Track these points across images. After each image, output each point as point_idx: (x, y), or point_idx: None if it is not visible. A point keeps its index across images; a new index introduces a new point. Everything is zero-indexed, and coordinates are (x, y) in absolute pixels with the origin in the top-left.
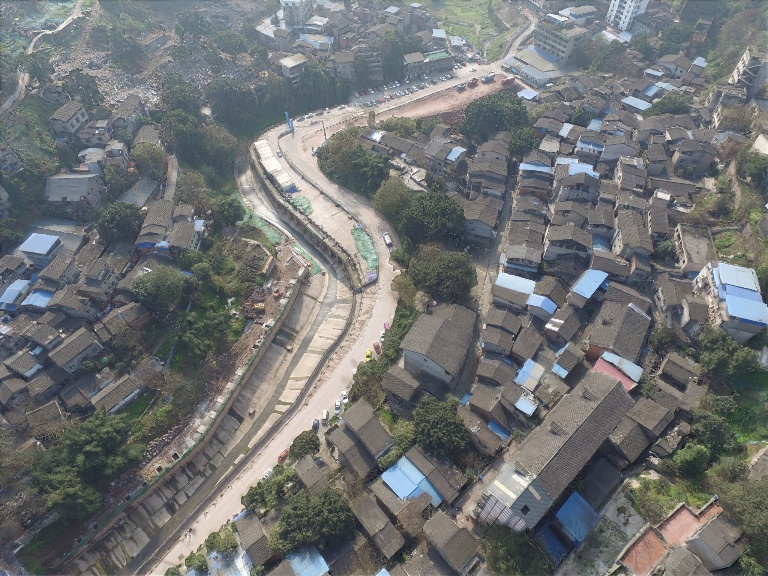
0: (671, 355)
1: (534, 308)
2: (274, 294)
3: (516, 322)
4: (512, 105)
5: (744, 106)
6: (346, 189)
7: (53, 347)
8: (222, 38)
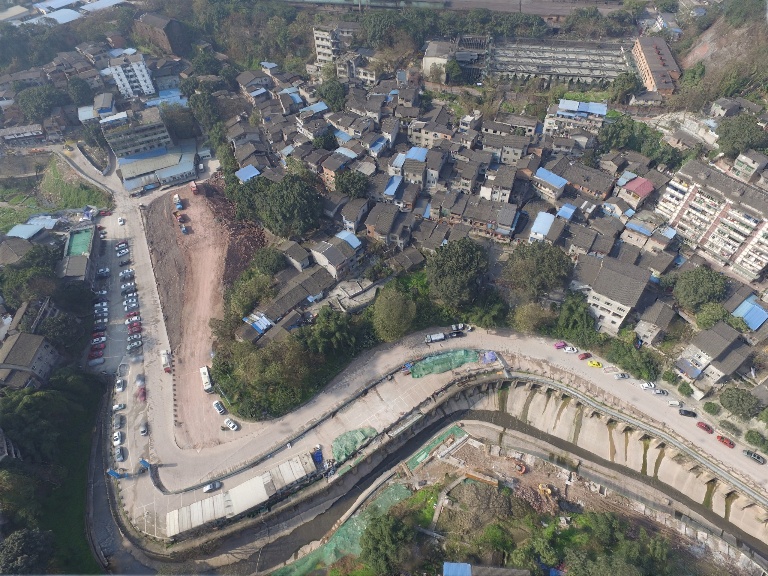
0: (605, 160)
1: None
2: (524, 471)
3: (586, 229)
4: (282, 181)
5: (363, 60)
6: (332, 382)
7: None
8: None
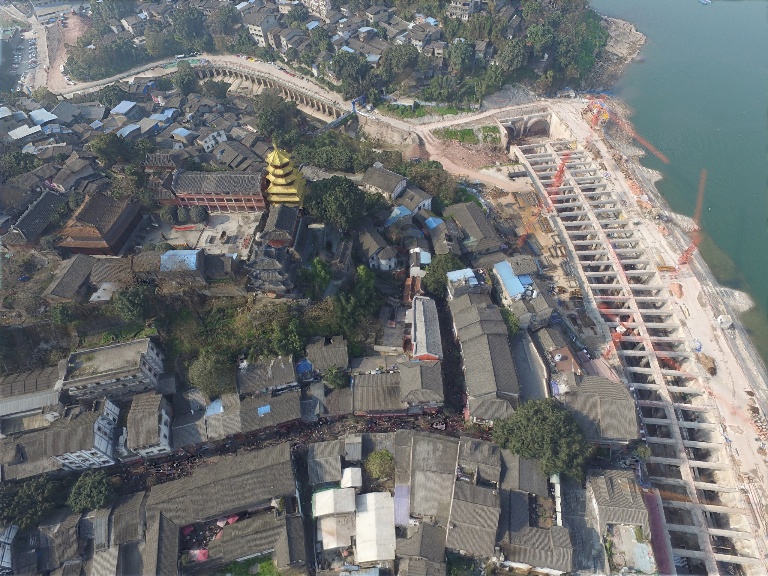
0: None
1: (255, 2)
2: None
3: None
4: None
5: None
6: (124, 72)
7: (208, 107)
8: None
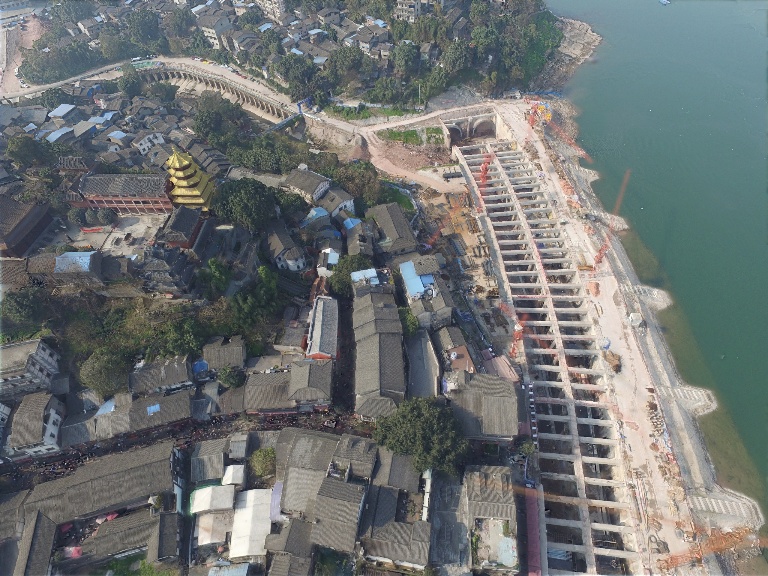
0: None
1: (212, 5)
2: None
3: None
4: None
5: None
6: (79, 74)
7: (150, 110)
8: None
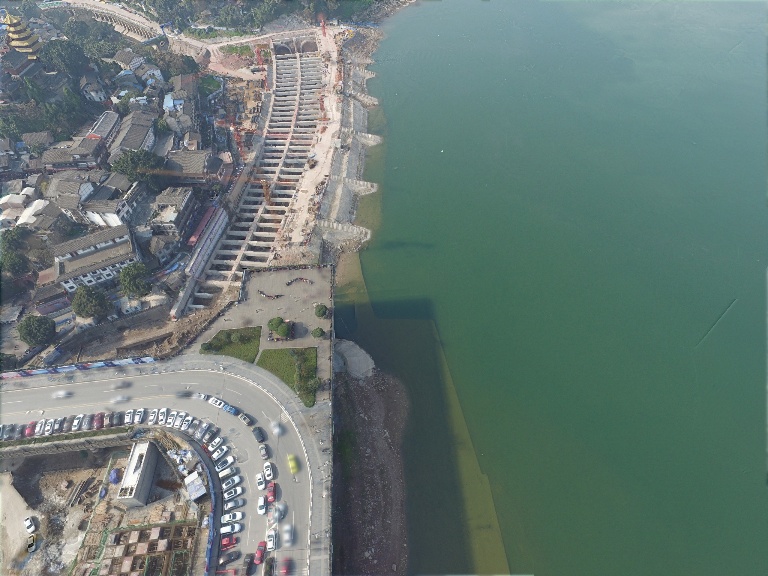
0: None
1: None
2: None
3: None
4: None
5: None
6: None
7: (39, 25)
8: None
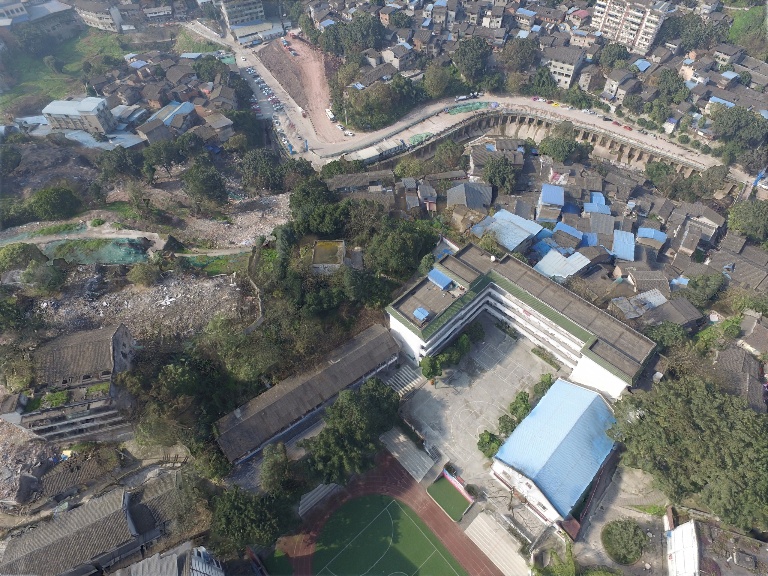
0: (560, 5)
1: None
2: None
3: None
4: None
5: None
6: (403, 118)
7: None
8: (168, 149)
